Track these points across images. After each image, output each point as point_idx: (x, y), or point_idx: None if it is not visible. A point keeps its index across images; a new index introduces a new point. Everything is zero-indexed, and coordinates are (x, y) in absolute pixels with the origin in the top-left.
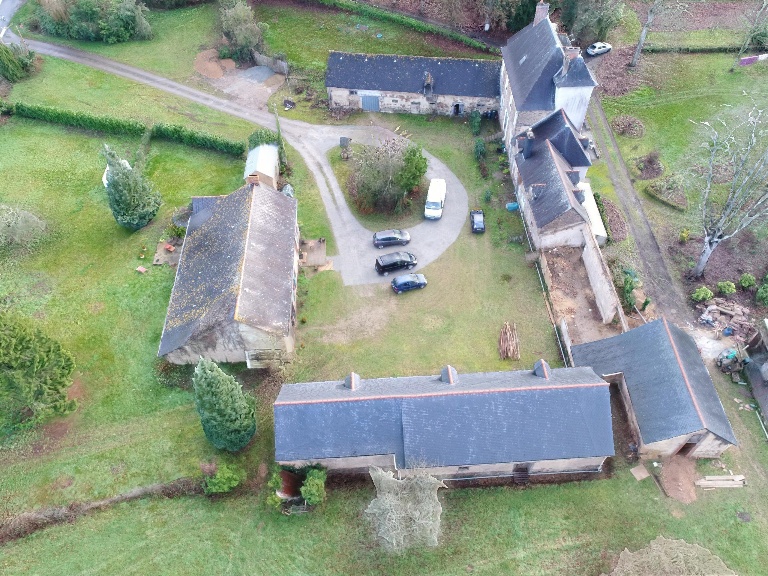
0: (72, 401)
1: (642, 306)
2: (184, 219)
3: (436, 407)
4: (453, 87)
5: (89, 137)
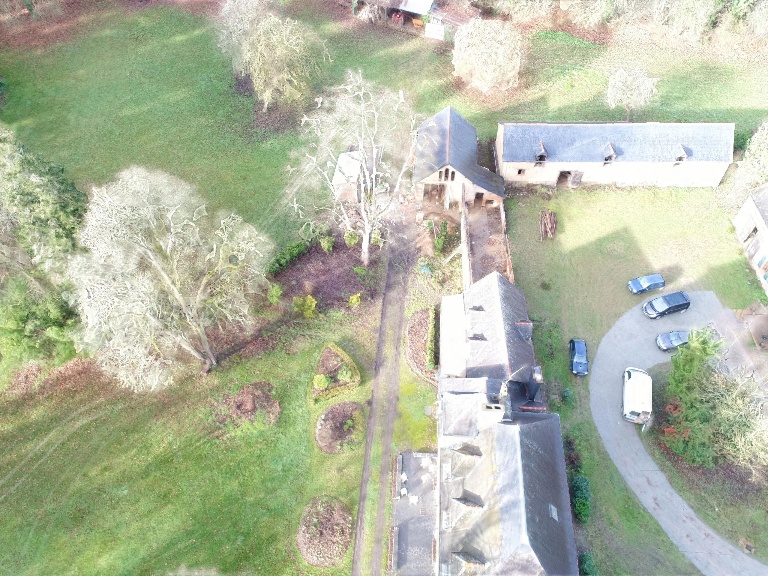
0: None
1: None
2: None
3: None
4: None
5: None
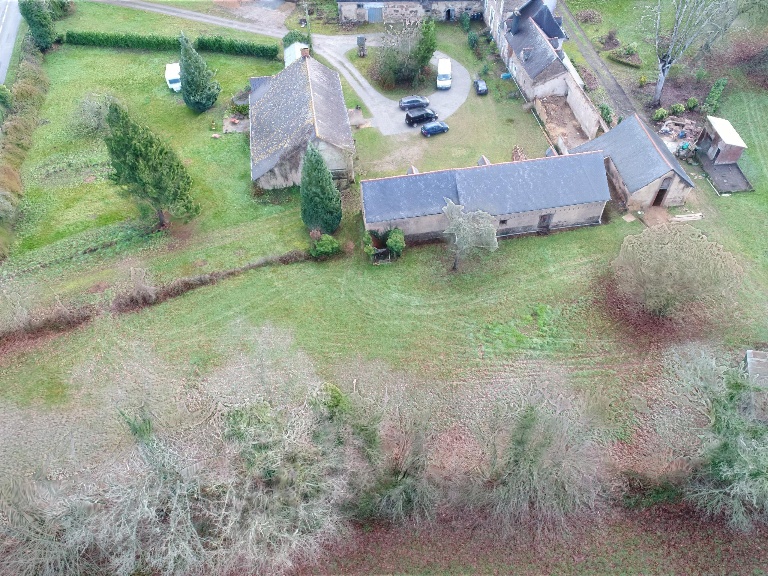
0: (197, 206)
1: (617, 124)
2: (243, 99)
3: (480, 175)
4: None
5: (138, 54)
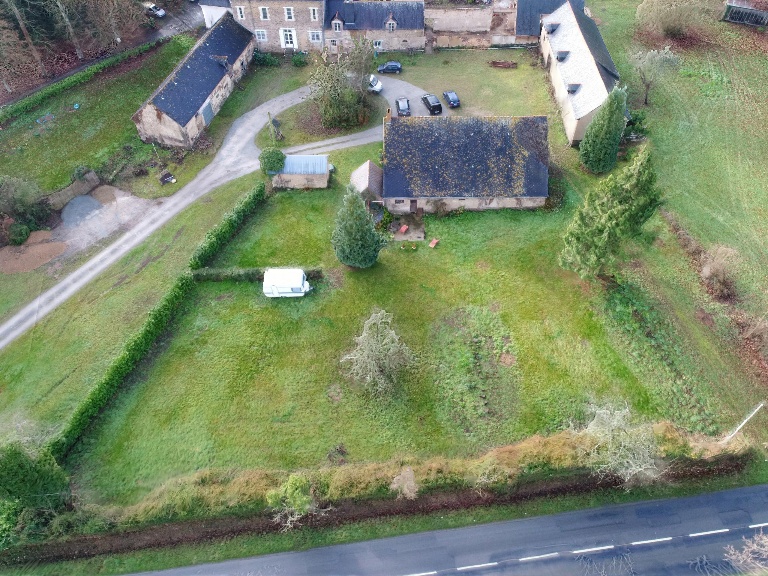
0: None
1: None
2: (375, 212)
3: None
4: (232, 51)
5: (166, 349)
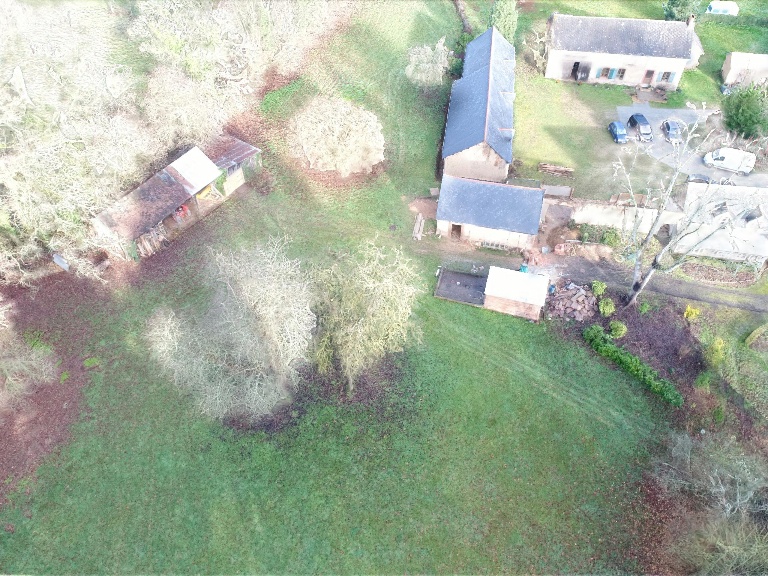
0: None
1: None
2: None
3: None
4: None
5: None
